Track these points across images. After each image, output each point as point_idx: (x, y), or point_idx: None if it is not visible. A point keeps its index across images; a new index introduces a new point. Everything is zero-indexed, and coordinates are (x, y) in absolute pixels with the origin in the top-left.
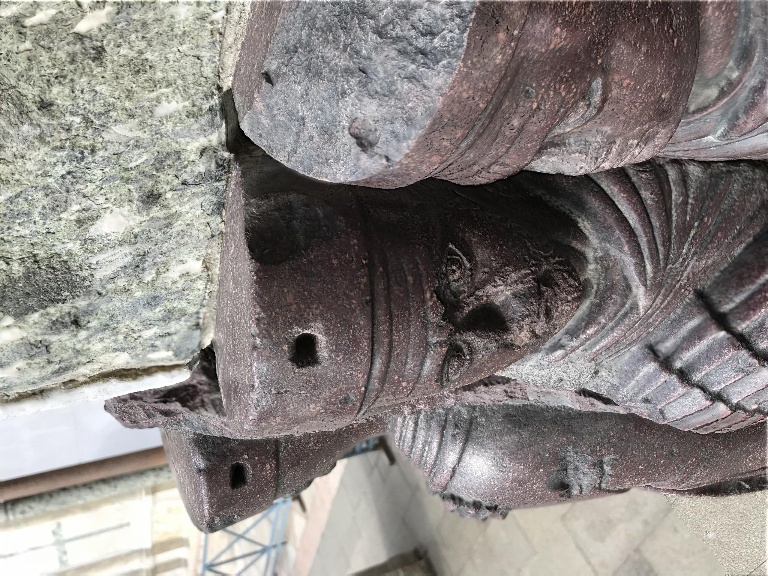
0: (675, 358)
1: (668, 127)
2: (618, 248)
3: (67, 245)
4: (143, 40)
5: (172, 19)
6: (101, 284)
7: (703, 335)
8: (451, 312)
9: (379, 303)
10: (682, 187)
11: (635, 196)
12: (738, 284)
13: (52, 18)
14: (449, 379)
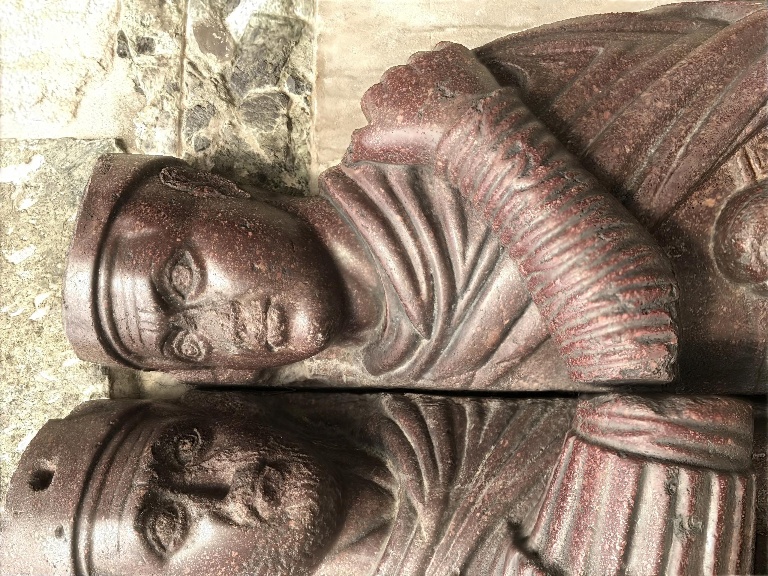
0: None
1: (302, 301)
2: (402, 471)
3: (5, 456)
4: None
5: None
6: None
7: None
8: (166, 469)
9: (108, 450)
10: (476, 416)
11: (417, 422)
12: None
13: (22, 312)
14: (166, 548)
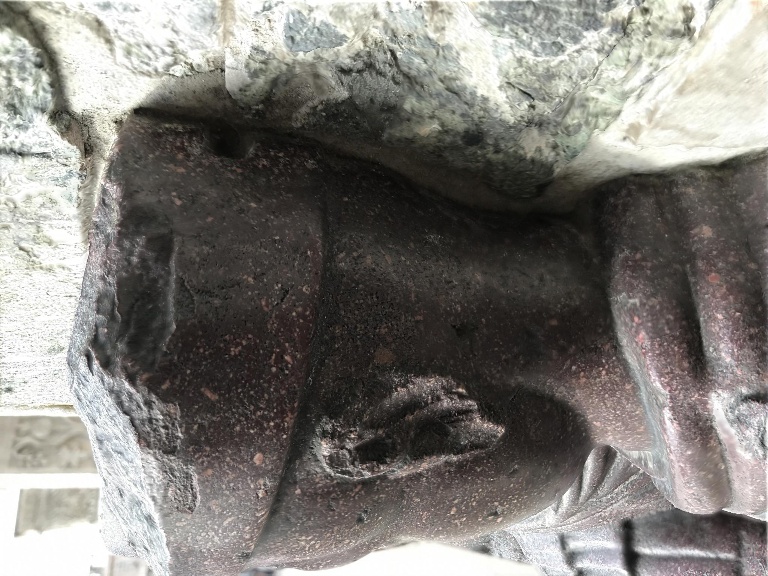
0: (578, 559)
1: None
2: None
3: None
4: (6, 288)
5: (32, 280)
6: (24, 380)
7: (607, 561)
8: None
9: None
10: None
11: None
12: (662, 537)
13: None
14: None
